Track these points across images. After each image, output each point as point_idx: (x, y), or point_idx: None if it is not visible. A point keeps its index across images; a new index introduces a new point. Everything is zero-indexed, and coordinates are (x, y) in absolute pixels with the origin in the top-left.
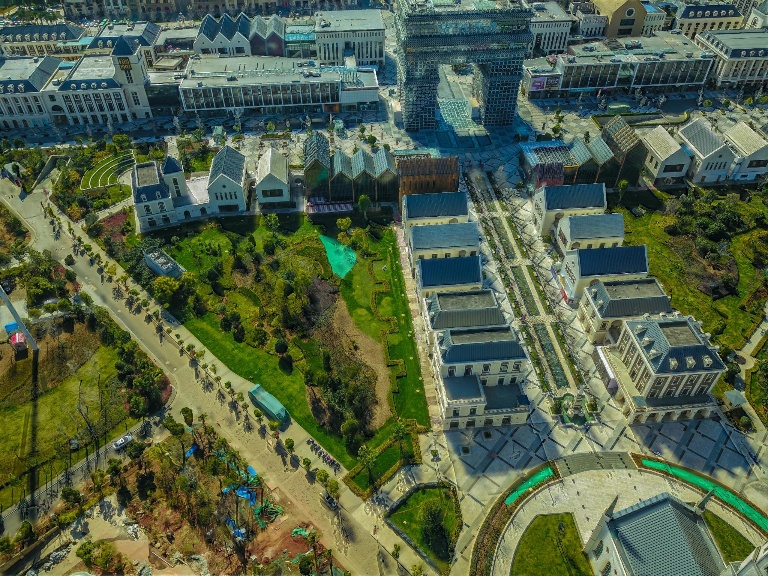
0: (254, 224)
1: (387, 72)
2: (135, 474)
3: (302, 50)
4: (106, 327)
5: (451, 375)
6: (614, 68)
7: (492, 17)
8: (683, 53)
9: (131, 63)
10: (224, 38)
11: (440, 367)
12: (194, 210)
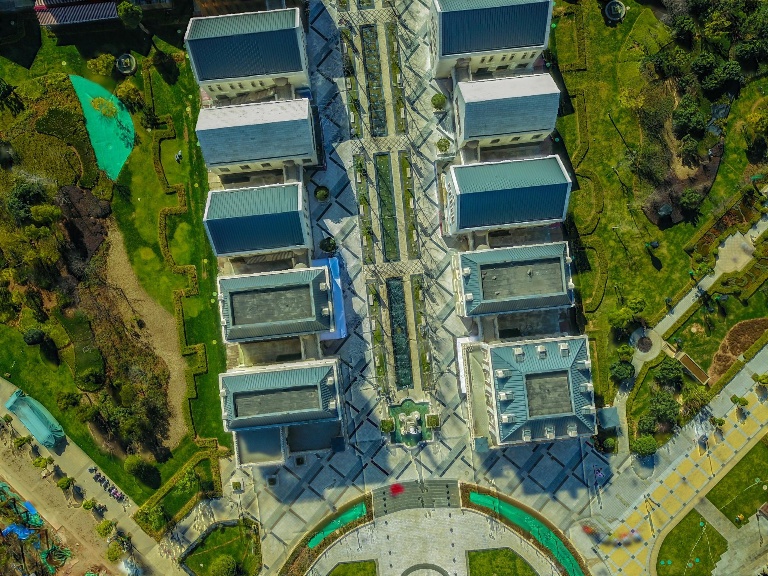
0: None
1: None
2: None
3: None
4: None
5: None
6: None
7: None
8: None
9: None
10: None
11: None
12: None
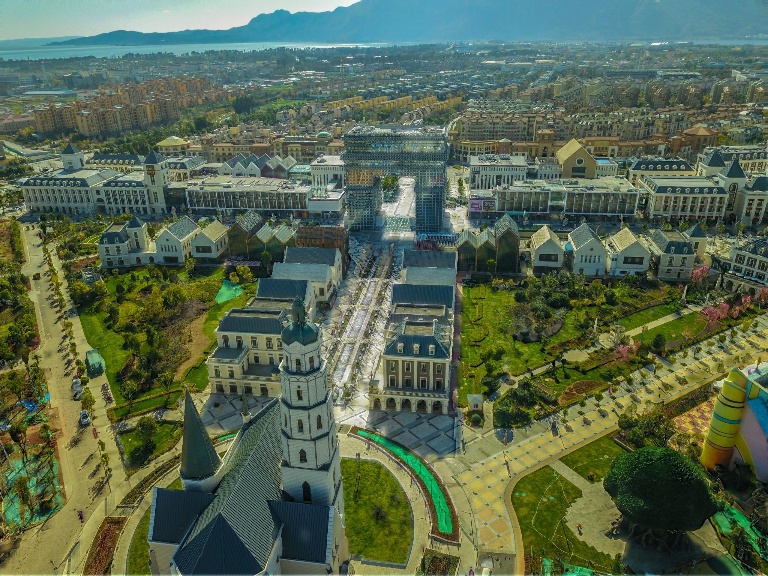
0: (182, 270)
1: None
2: None
3: (302, 180)
4: None
5: (227, 346)
6: (544, 196)
7: (411, 139)
8: (613, 188)
9: (155, 170)
10: (241, 166)
11: None
12: (144, 257)
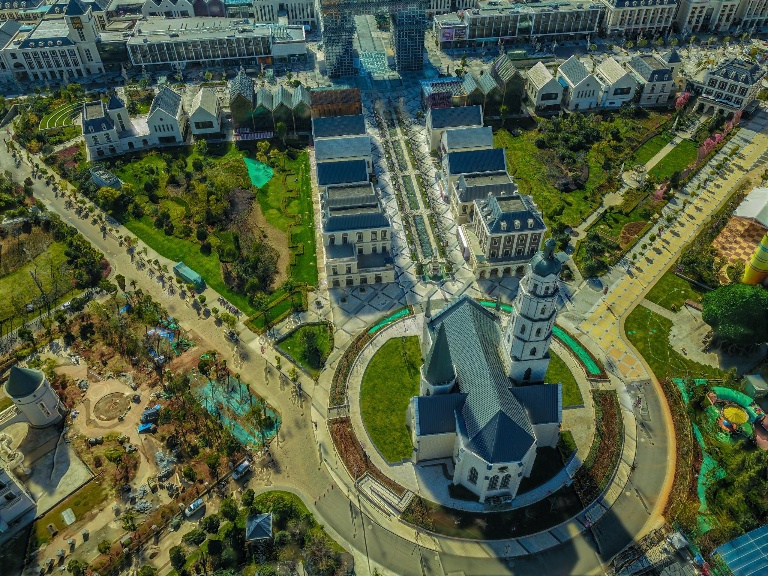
0: (188, 151)
1: (319, 31)
2: (78, 324)
3: (241, 13)
4: (58, 228)
5: (332, 244)
6: (513, 19)
7: None
8: (575, 5)
9: (82, 22)
10: (169, 2)
11: (322, 237)
12: (137, 141)
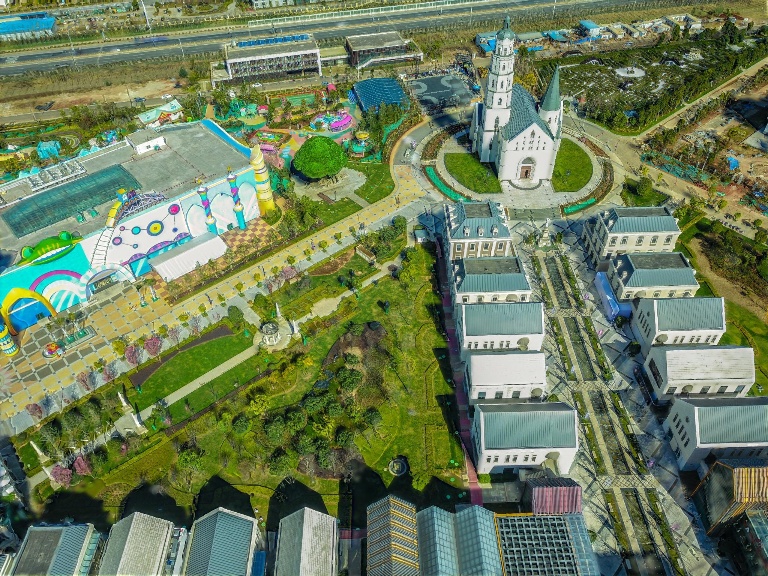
0: None
1: None
2: None
3: None
4: None
5: None
6: None
7: None
8: None
9: None
10: None
11: None
12: None
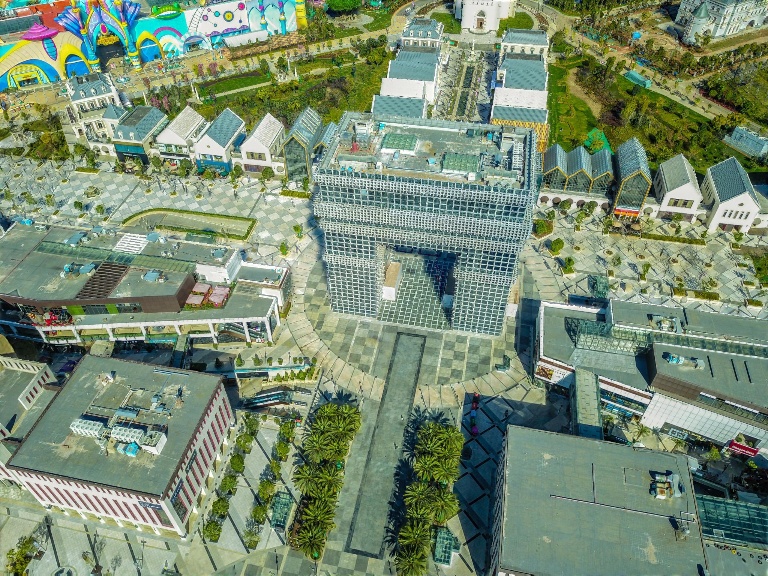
0: None
1: (496, 451)
2: None
3: None
4: None
5: None
6: None
7: None
8: (37, 239)
9: None
10: None
11: None
12: None
